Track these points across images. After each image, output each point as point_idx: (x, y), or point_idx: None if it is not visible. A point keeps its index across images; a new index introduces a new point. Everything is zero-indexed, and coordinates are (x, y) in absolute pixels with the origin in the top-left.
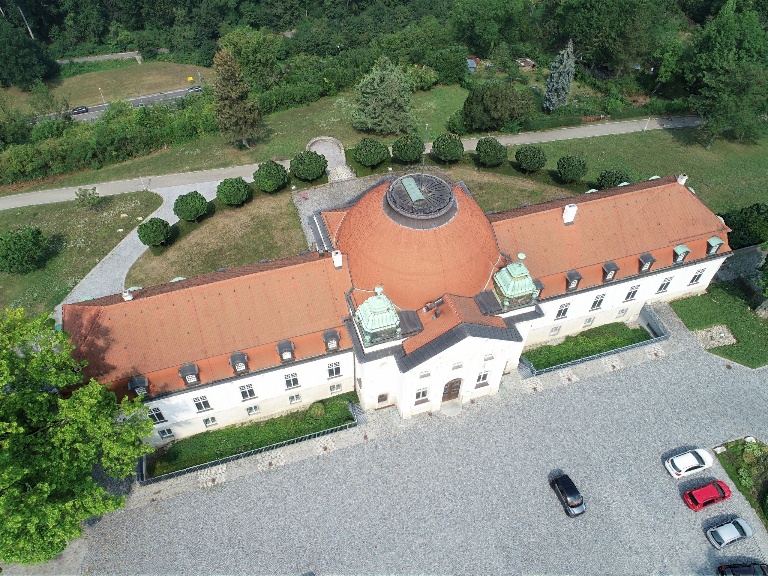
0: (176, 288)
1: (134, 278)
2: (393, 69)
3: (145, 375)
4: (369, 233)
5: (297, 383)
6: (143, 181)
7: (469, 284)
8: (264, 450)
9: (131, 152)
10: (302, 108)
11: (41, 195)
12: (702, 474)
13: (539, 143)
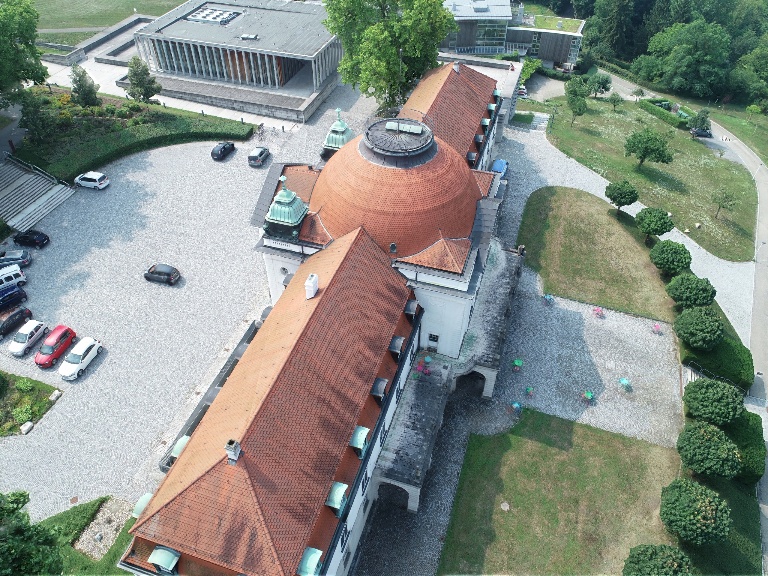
0: None
1: (585, 195)
2: None
3: None
4: None
5: None
6: None
7: None
8: None
9: None
10: None
11: None
12: None
13: None
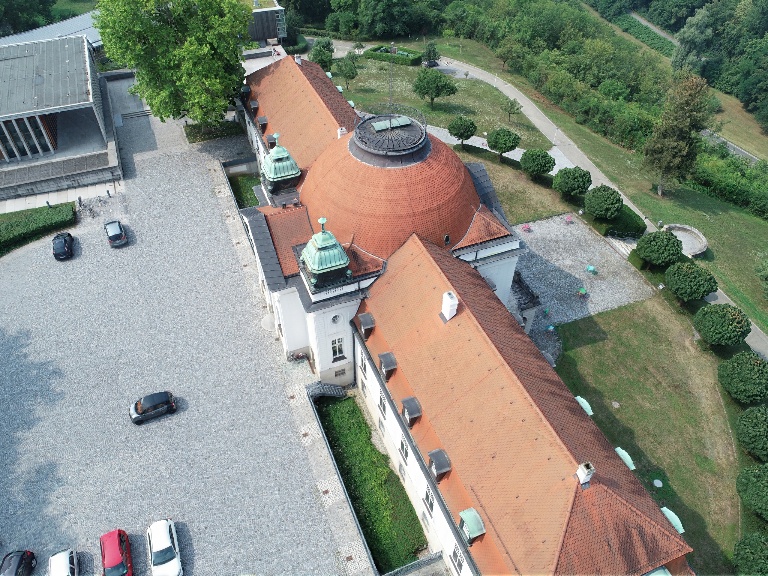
0: None
1: None
2: None
3: None
4: None
5: None
6: (566, 142)
7: None
8: None
9: None
10: None
11: (528, 104)
12: (151, 572)
13: None
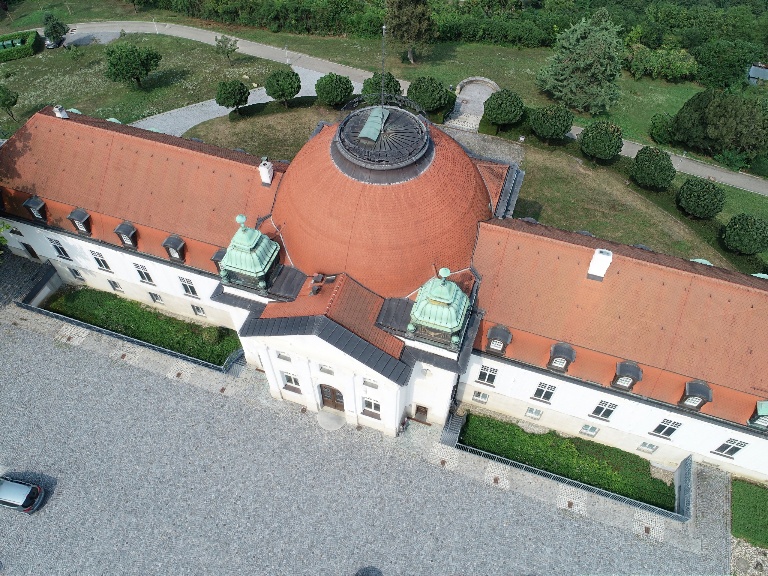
0: (113, 129)
1: (195, 132)
2: (608, 28)
3: (44, 199)
4: (304, 156)
5: (196, 293)
6: (294, 56)
7: (382, 278)
8: (126, 339)
9: (311, 28)
10: (510, 49)
11: (212, 36)
12: None
13: (757, 194)
